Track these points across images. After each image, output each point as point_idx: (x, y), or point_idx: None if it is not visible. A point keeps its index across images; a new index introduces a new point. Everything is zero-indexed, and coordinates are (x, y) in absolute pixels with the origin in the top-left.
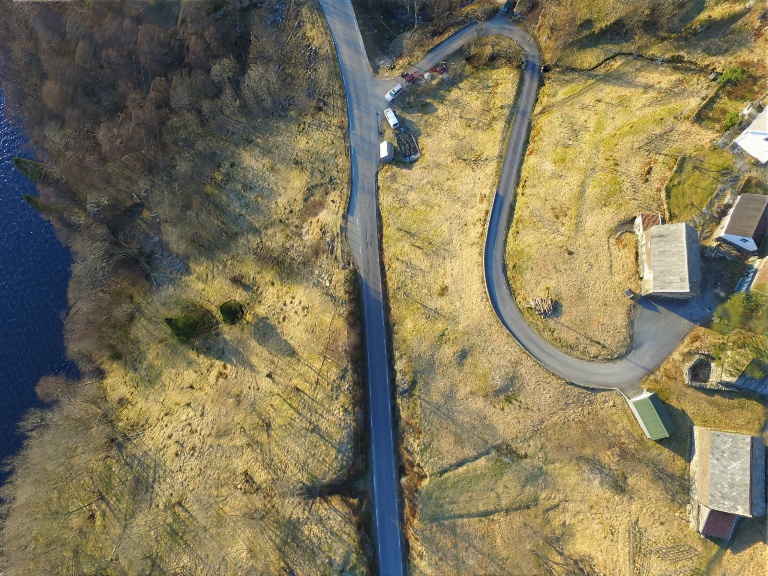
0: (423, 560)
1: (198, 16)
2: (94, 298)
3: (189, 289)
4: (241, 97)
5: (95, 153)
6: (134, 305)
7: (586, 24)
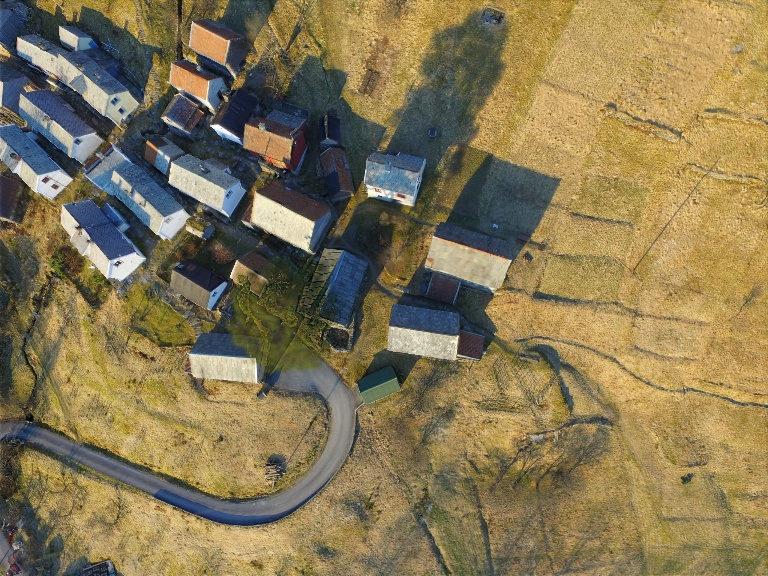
0: None
1: None
2: None
3: None
4: None
5: None
6: None
7: None
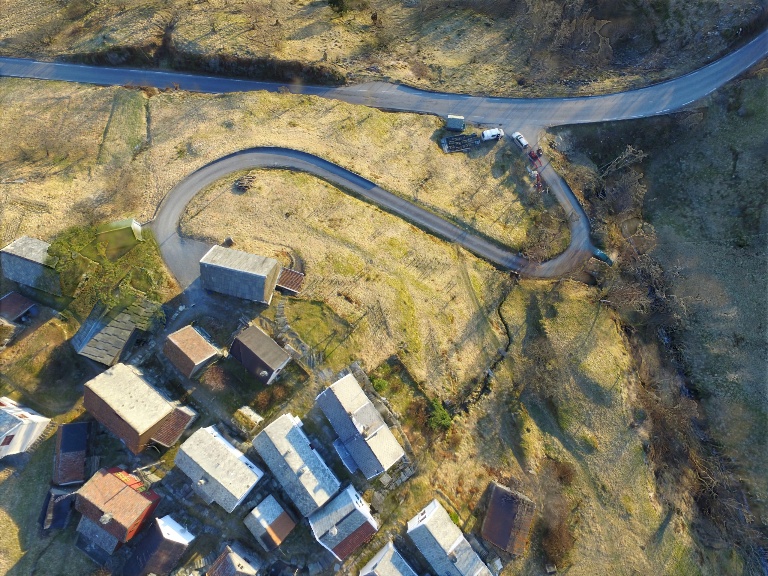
0: (92, 89)
1: None
2: None
3: (389, 5)
4: None
5: None
6: None
7: (553, 312)
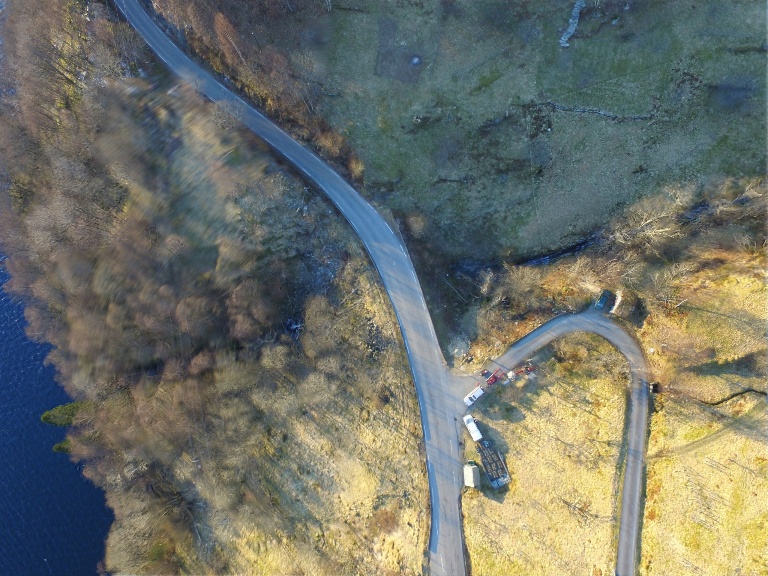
0: None
1: (239, 265)
2: None
3: (239, 555)
4: None
5: (132, 422)
6: (177, 558)
7: (707, 352)
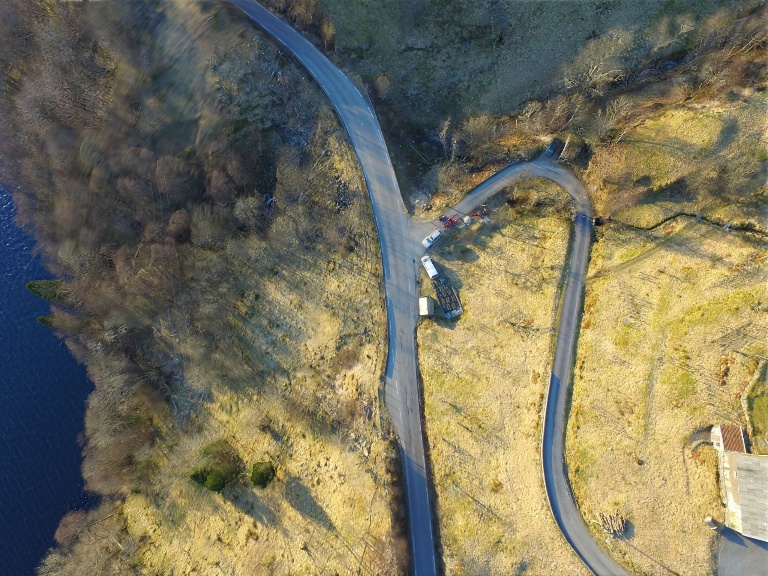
0: None
1: (218, 137)
2: (113, 433)
3: (212, 418)
4: (265, 224)
5: (112, 283)
6: (154, 428)
7: (643, 180)
